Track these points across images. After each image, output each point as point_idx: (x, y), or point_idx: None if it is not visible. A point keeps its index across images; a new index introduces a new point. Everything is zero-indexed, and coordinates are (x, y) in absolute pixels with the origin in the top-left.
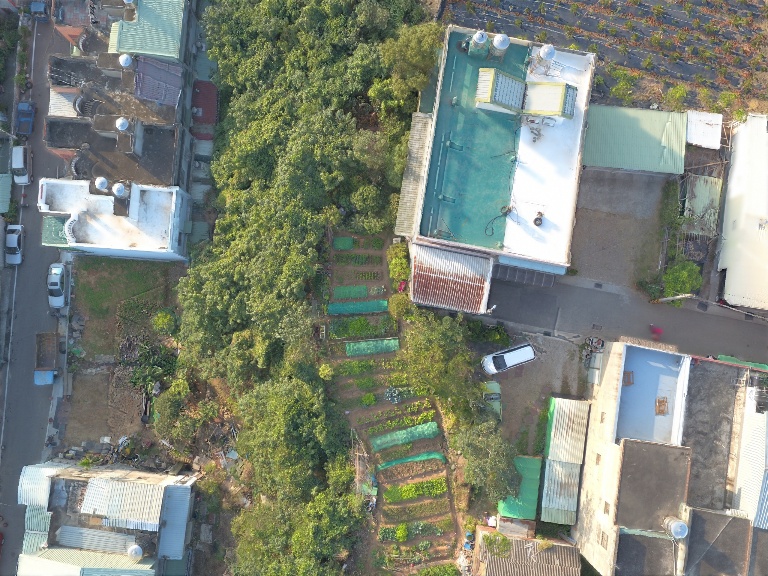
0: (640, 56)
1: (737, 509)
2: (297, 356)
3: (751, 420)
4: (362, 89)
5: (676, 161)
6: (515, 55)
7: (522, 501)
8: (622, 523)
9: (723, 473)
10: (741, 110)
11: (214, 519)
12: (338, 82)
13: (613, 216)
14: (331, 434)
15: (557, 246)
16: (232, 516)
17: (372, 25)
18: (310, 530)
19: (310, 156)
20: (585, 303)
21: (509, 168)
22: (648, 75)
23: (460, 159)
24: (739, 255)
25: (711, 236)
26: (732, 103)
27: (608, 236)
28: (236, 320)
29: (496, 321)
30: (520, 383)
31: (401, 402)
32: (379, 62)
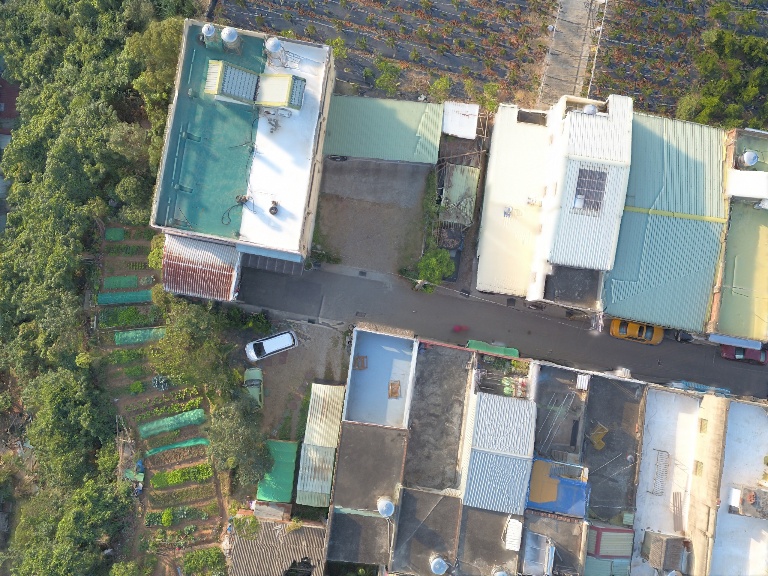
0: (408, 49)
1: (453, 488)
2: (58, 345)
3: (472, 402)
4: (131, 82)
5: (430, 151)
6: (254, 48)
7: (277, 484)
8: (339, 503)
9: (454, 454)
10: (492, 101)
11: (10, 507)
12: (106, 76)
13: (378, 205)
14: (98, 421)
15: (293, 234)
16: (23, 504)
17: (139, 19)
18: (71, 515)
19: (71, 148)
20: (349, 291)
21: (246, 158)
22: (417, 67)
23: (198, 150)
24: (485, 242)
25: (467, 224)
26: (499, 94)
27: (373, 225)
28: (22, 311)
29: (261, 309)
30: (284, 370)
31: (169, 389)
32: (144, 56)
